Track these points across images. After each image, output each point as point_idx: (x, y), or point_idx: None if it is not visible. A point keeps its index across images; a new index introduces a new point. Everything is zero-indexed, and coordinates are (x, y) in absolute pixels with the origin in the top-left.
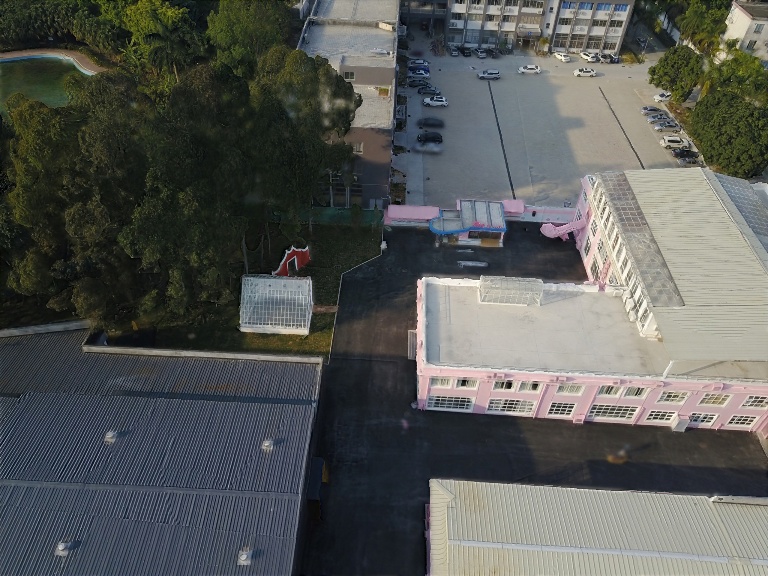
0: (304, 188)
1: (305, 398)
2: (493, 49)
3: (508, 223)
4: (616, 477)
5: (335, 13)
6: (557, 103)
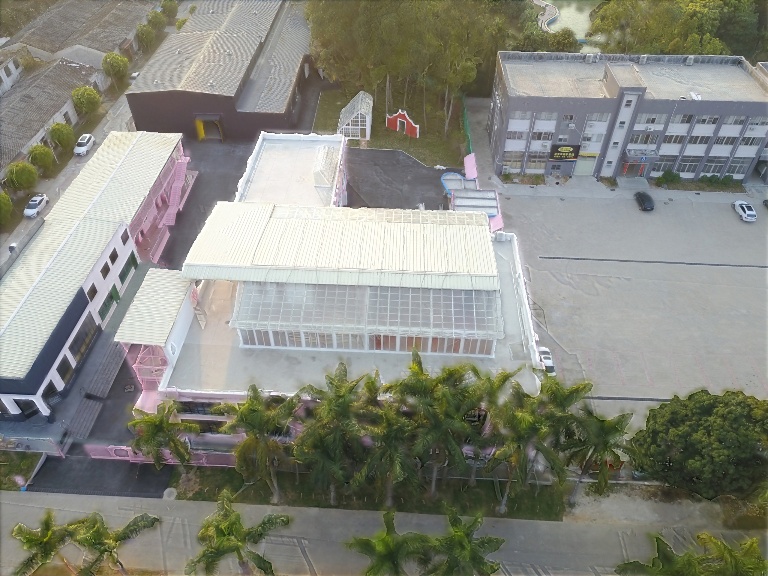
0: None
1: (256, 110)
2: None
3: None
4: None
5: None
6: None
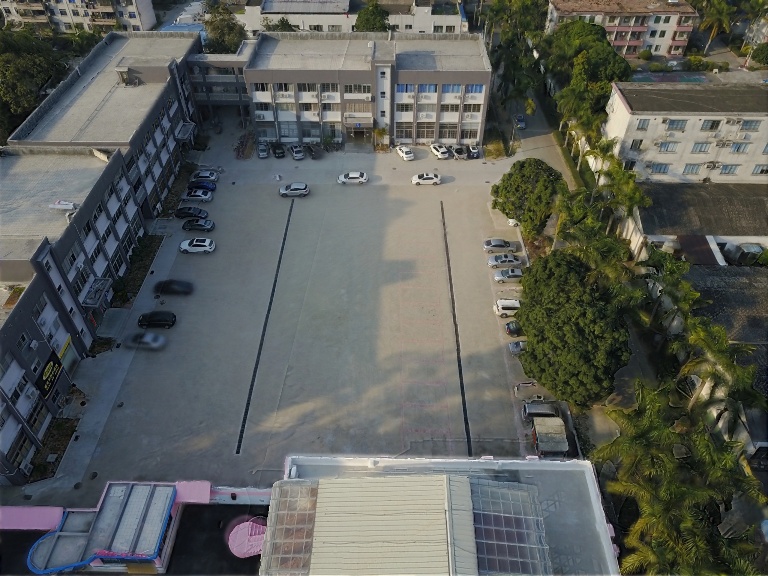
0: None
1: None
2: (314, 146)
3: (197, 510)
4: None
5: (59, 127)
6: (372, 235)
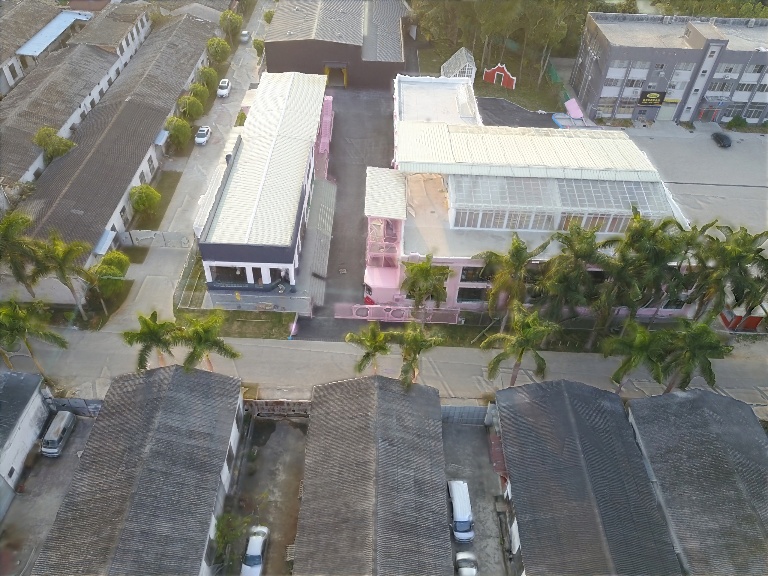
0: (490, 1)
1: (378, 60)
2: None
3: None
4: (354, 173)
5: None
6: None
